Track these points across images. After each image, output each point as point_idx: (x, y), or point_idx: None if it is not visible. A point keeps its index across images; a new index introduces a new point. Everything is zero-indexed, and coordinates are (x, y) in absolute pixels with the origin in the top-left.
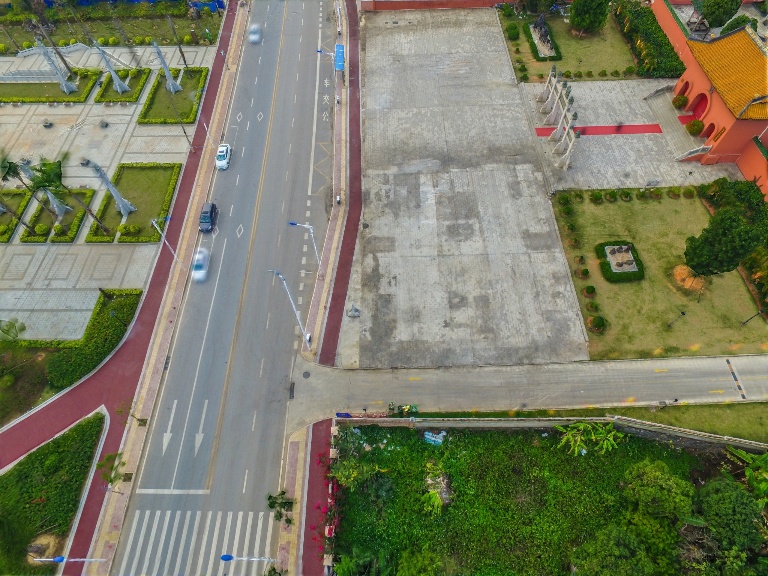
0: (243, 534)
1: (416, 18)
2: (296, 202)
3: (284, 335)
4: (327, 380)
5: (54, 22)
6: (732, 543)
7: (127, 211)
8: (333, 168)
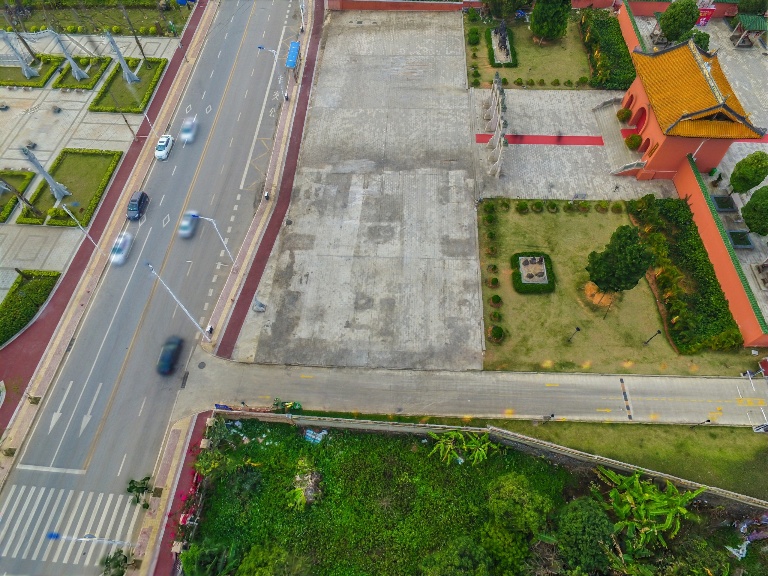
0: (109, 515)
1: (381, 19)
2: (226, 195)
3: (188, 325)
4: (221, 372)
5: (30, 8)
6: (578, 563)
7: (61, 195)
8: (269, 164)
